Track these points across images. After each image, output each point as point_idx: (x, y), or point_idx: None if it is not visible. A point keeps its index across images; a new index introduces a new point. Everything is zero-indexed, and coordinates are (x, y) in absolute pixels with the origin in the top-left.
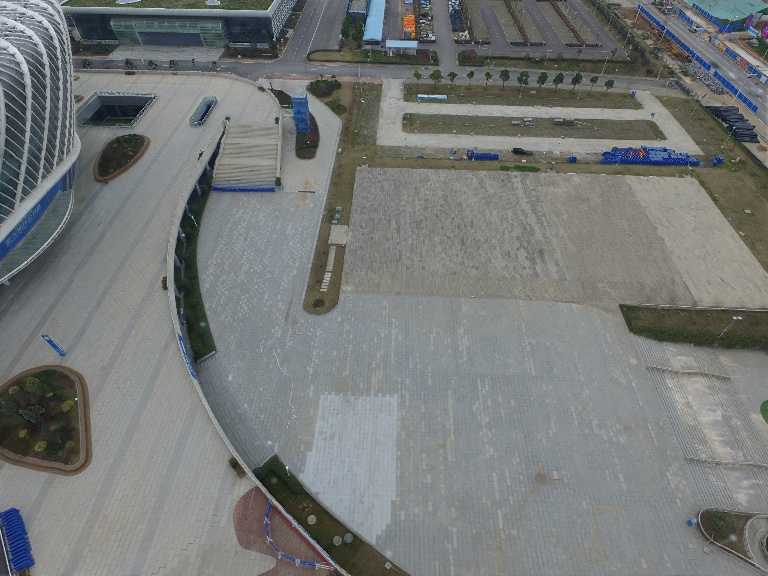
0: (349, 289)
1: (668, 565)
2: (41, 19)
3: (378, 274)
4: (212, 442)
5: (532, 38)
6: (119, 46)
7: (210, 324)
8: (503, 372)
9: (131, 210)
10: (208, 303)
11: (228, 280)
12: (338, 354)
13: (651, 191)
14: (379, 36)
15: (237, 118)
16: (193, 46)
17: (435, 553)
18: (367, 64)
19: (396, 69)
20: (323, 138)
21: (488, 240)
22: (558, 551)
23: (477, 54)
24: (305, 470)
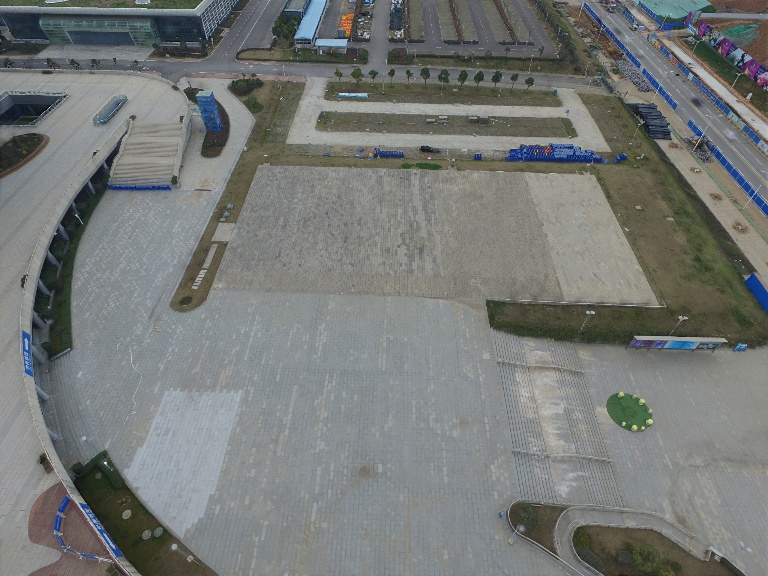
0: (220, 286)
1: (469, 556)
2: None
3: (253, 271)
4: (29, 438)
5: (467, 36)
6: (50, 45)
7: (73, 322)
8: (354, 367)
9: (11, 209)
10: (76, 301)
11: (102, 278)
12: (193, 351)
13: (547, 188)
14: (311, 35)
15: (143, 117)
16: (124, 45)
17: (240, 546)
18: (295, 63)
19: (323, 68)
20: (232, 136)
21: (371, 237)
22: (363, 543)
23: (408, 52)
24: (131, 465)
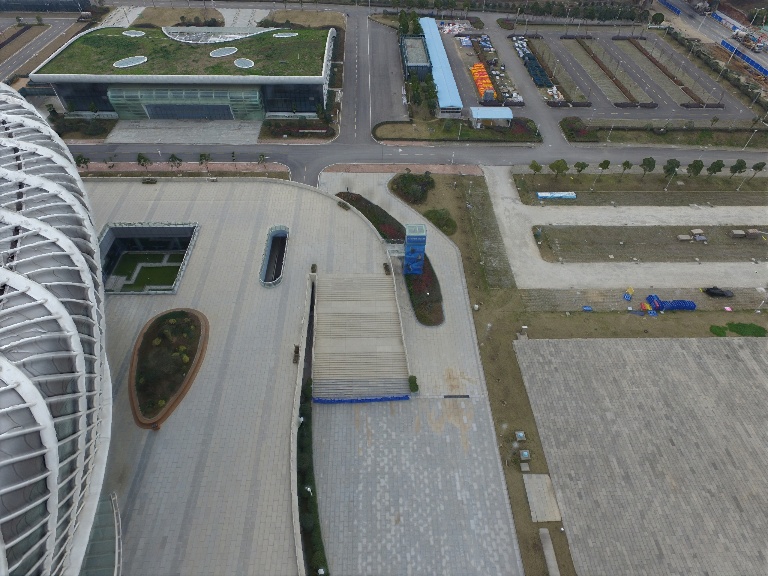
0: None
1: None
2: (55, 235)
3: None
4: None
5: (636, 95)
6: (118, 121)
7: None
8: None
9: (212, 500)
10: None
11: None
12: None
13: None
14: (459, 101)
15: (326, 265)
16: (219, 119)
17: None
18: (453, 143)
19: (492, 150)
20: (443, 281)
21: None
22: None
23: (583, 122)
24: None
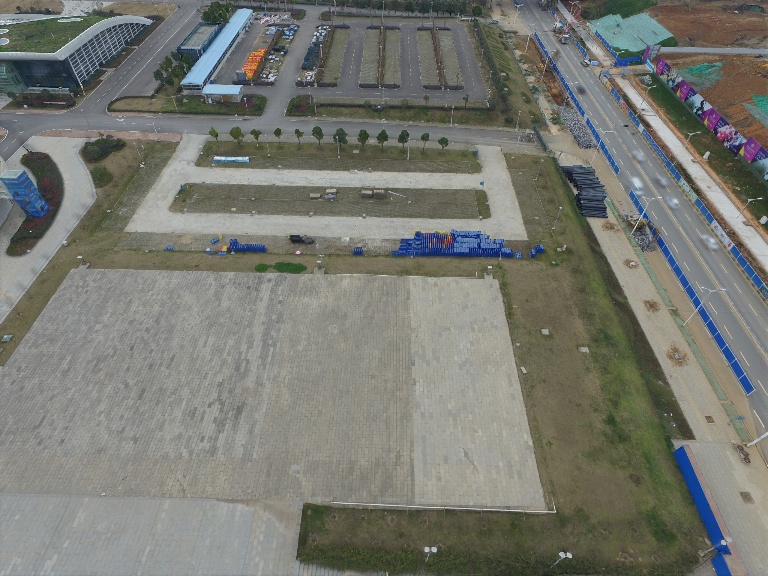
0: None
1: None
2: None
3: None
4: None
5: (389, 78)
6: None
7: None
8: None
9: None
10: None
11: None
12: None
13: (432, 301)
14: (201, 79)
15: None
16: None
17: None
18: (176, 115)
19: (207, 121)
20: (57, 223)
21: (178, 389)
22: None
23: (313, 100)
24: None
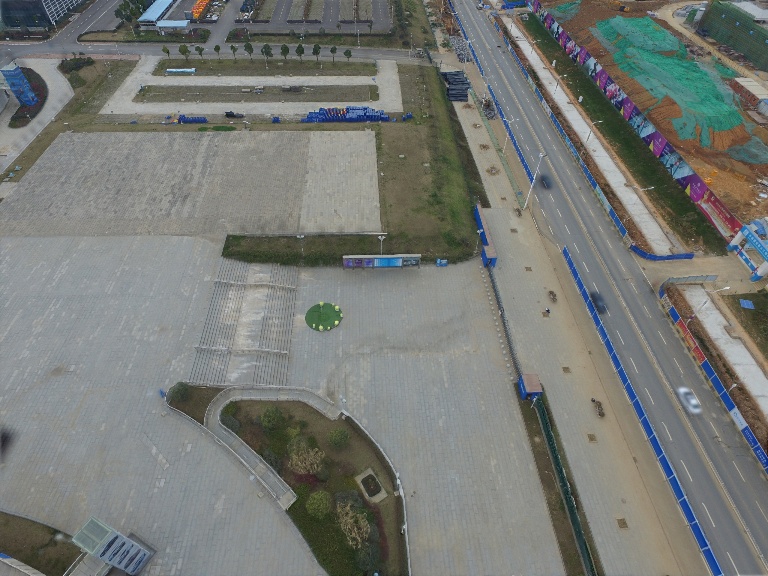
0: None
1: (123, 426)
2: None
3: (18, 221)
4: None
5: (312, 16)
6: None
7: None
8: (81, 293)
9: None
10: None
11: None
12: None
13: (326, 143)
14: None
15: None
16: None
17: None
18: (135, 43)
19: (161, 47)
20: (46, 109)
21: (143, 189)
22: (33, 423)
23: (249, 32)
24: None
